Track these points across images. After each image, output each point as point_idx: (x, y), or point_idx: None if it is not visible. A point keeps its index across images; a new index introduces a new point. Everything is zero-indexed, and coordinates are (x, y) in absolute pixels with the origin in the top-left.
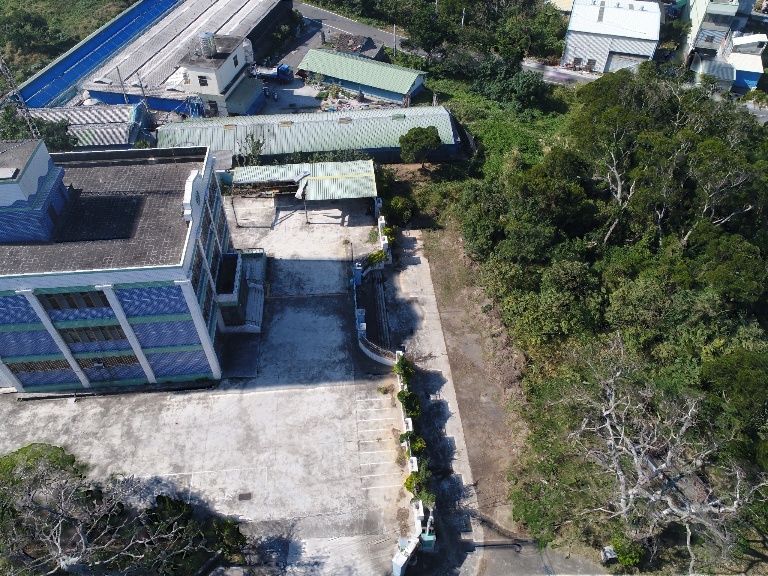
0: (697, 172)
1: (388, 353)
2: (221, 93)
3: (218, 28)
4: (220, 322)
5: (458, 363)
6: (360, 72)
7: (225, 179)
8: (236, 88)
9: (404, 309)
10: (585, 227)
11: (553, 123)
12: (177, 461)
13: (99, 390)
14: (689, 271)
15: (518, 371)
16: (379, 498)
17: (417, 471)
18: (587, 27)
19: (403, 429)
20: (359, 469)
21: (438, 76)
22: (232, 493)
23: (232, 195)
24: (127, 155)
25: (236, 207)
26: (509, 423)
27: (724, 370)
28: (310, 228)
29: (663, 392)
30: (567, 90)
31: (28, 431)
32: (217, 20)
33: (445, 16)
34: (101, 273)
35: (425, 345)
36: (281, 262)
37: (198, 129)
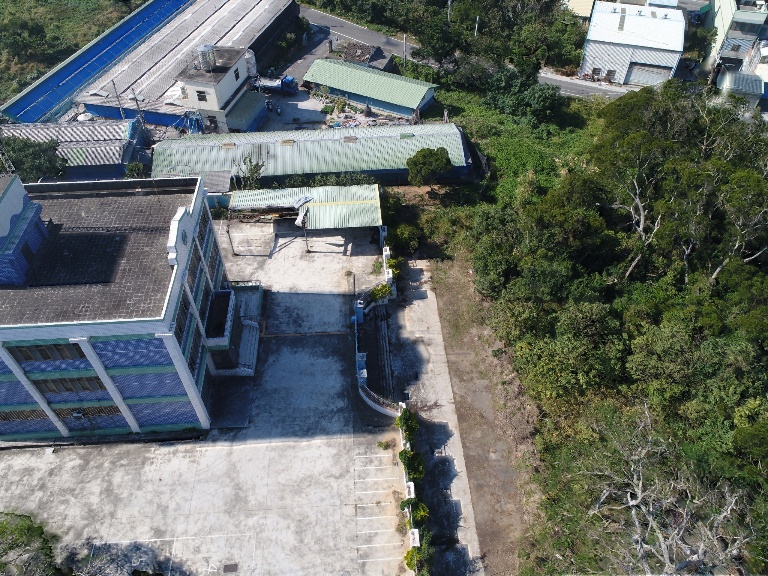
0: (729, 208)
1: (390, 404)
2: (221, 109)
3: (221, 37)
4: (210, 365)
5: (466, 413)
6: (368, 84)
7: (222, 202)
8: (237, 102)
9: (409, 350)
10: (604, 259)
11: (570, 139)
12: (159, 524)
13: (79, 439)
14: (718, 313)
15: (531, 426)
16: (377, 573)
17: (419, 546)
18: (607, 36)
19: (405, 491)
20: (356, 538)
21: (450, 87)
22: (217, 563)
23: (228, 222)
24: (112, 186)
25: (233, 233)
26: (520, 485)
27: (762, 440)
28: (310, 257)
29: (693, 463)
30: (585, 103)
31: (1, 486)
32: (220, 28)
33: (458, 25)
34: (75, 326)
35: (430, 392)
36: (278, 295)
37: (195, 147)
